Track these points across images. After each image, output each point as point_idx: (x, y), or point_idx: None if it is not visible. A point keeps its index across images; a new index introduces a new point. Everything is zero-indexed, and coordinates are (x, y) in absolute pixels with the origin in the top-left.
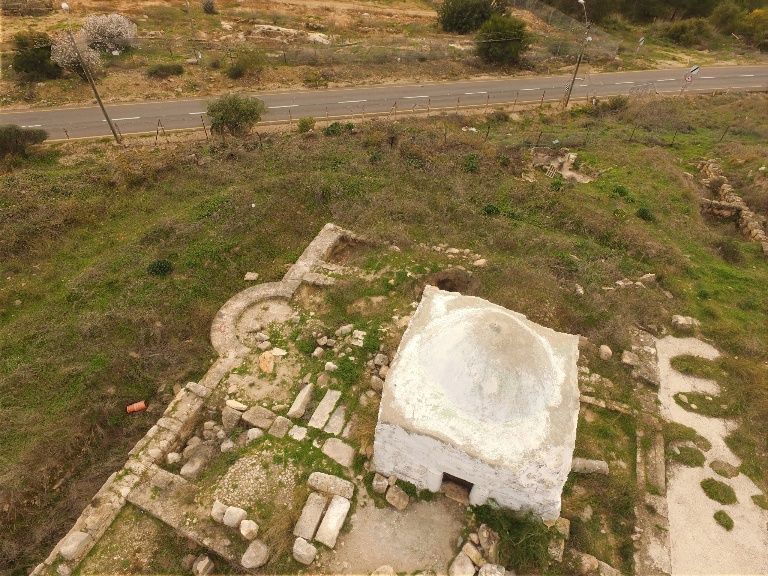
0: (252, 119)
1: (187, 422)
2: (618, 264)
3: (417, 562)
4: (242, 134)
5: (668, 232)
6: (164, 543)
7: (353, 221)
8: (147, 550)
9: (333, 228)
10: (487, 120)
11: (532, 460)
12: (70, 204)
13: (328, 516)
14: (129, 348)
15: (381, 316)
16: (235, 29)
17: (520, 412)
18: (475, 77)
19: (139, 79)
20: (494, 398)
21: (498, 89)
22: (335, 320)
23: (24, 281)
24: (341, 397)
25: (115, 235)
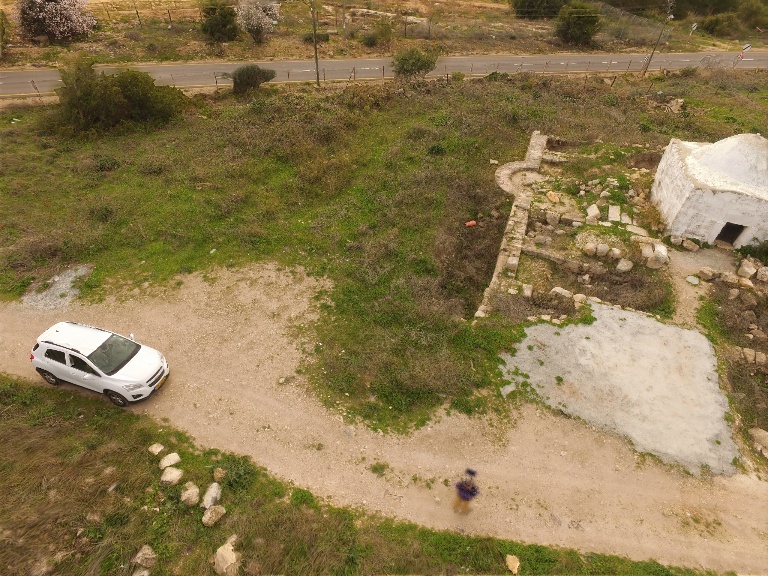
0: (431, 67)
1: None
2: None
3: None
4: None
5: None
6: (554, 270)
7: (548, 132)
8: (548, 272)
9: (540, 134)
10: None
11: None
12: None
13: None
14: None
15: None
16: None
17: None
18: (558, 53)
19: (297, 44)
20: (765, 172)
21: None
22: None
23: (345, 157)
24: (621, 208)
25: (383, 135)
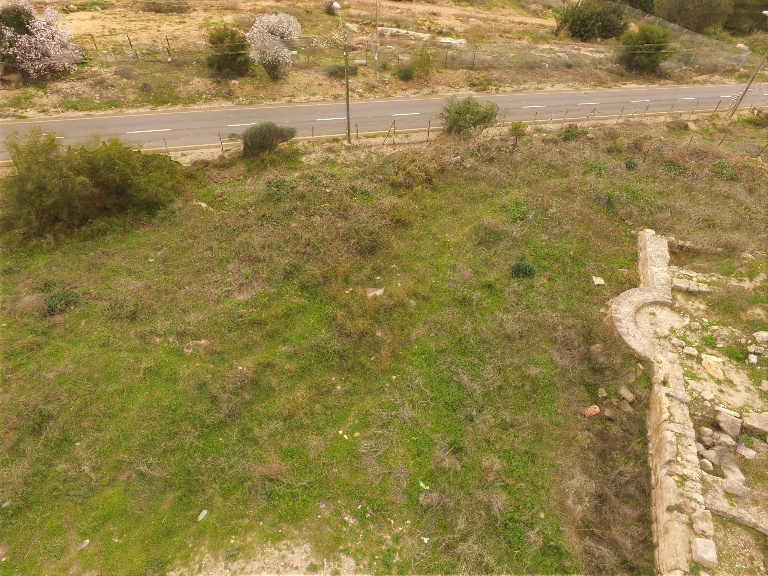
0: None
1: None
2: None
3: None
4: (472, 137)
5: None
6: (765, 551)
7: (661, 227)
8: (758, 558)
9: None
10: (668, 128)
11: None
12: (389, 204)
13: None
14: None
15: None
16: None
17: None
18: (622, 85)
19: (320, 79)
20: None
21: (657, 98)
22: (737, 327)
23: (396, 281)
24: None
25: (443, 236)
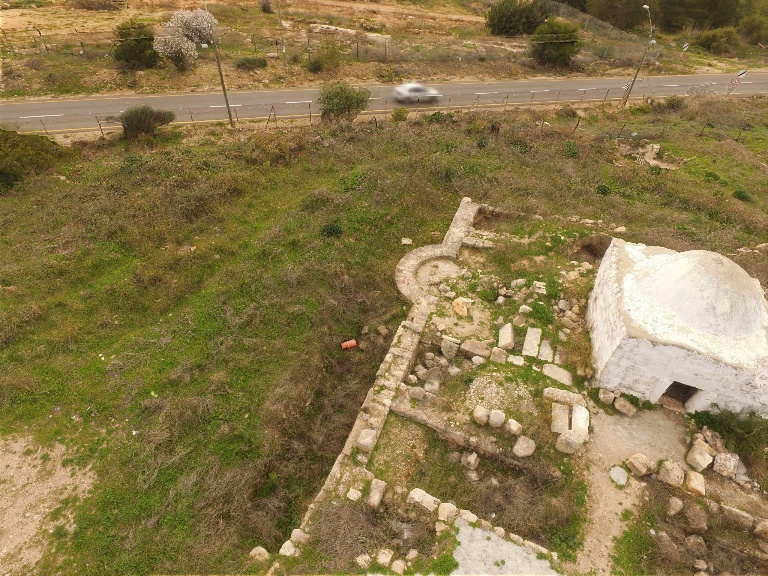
0: (362, 106)
1: (413, 352)
2: (733, 236)
3: (658, 454)
4: None
5: (766, 211)
6: (431, 443)
7: (483, 196)
8: (420, 447)
9: (470, 201)
10: (557, 115)
11: (765, 364)
12: (229, 176)
13: (575, 418)
14: (329, 296)
15: (549, 271)
16: (299, 27)
17: (746, 329)
18: (532, 77)
19: (228, 70)
20: (727, 316)
21: (558, 88)
22: None
23: (212, 240)
24: (543, 333)
25: (275, 204)
